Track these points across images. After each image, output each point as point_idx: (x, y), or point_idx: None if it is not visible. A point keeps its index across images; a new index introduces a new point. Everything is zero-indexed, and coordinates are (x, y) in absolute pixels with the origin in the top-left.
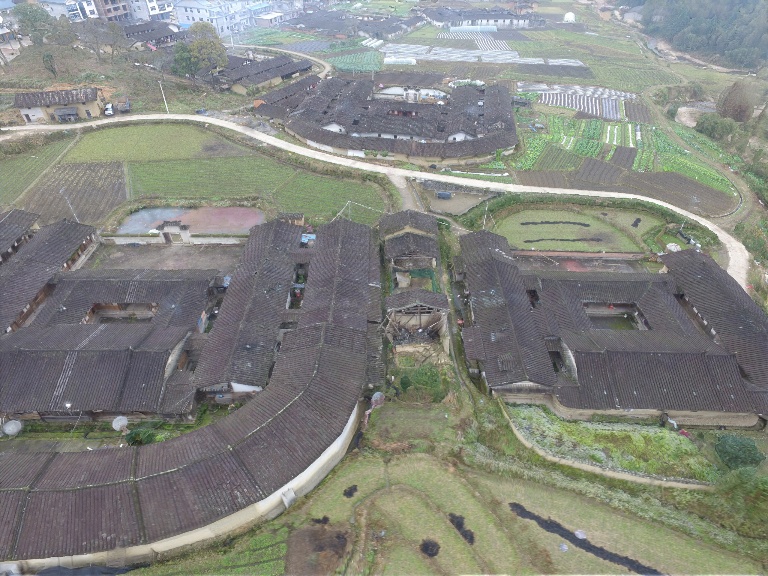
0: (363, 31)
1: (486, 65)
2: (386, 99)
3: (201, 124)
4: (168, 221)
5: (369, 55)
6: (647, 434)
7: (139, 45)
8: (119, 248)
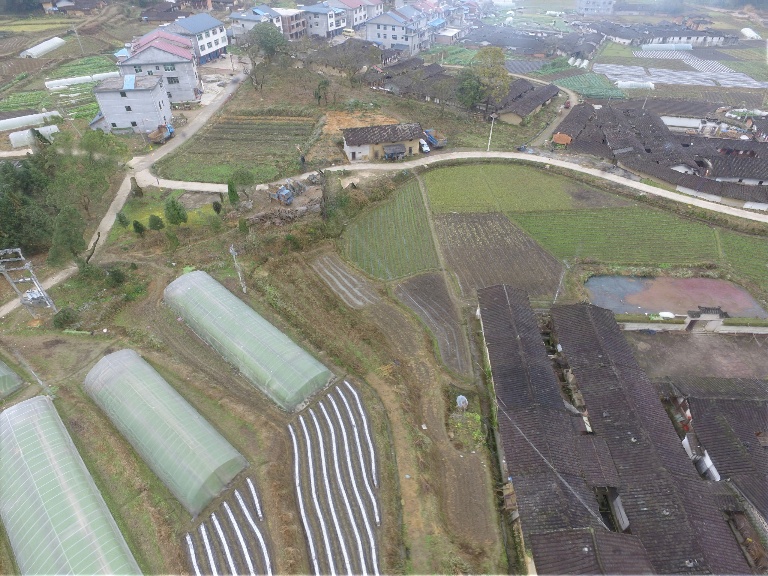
0: (560, 50)
1: (734, 90)
2: (676, 132)
3: (538, 165)
4: (709, 308)
5: (592, 77)
6: None
7: (365, 67)
8: (634, 336)
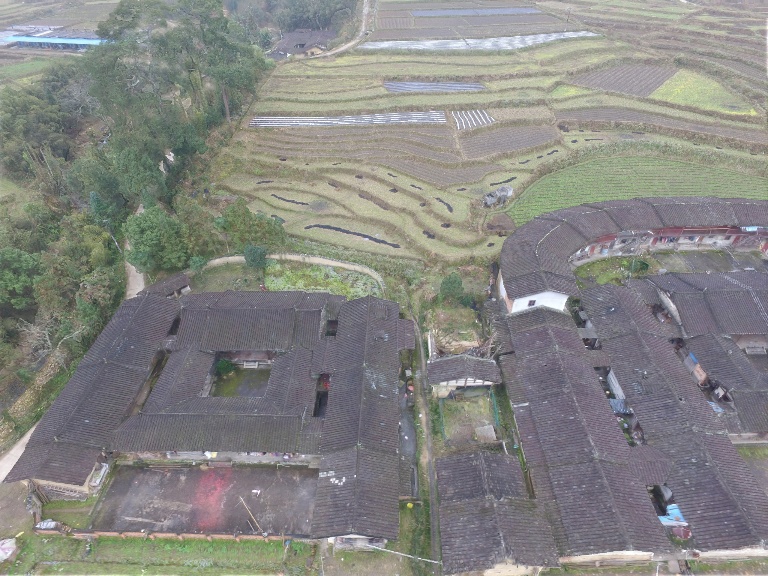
0: None
1: None
2: None
3: None
4: None
5: None
6: (292, 286)
7: None
8: None
